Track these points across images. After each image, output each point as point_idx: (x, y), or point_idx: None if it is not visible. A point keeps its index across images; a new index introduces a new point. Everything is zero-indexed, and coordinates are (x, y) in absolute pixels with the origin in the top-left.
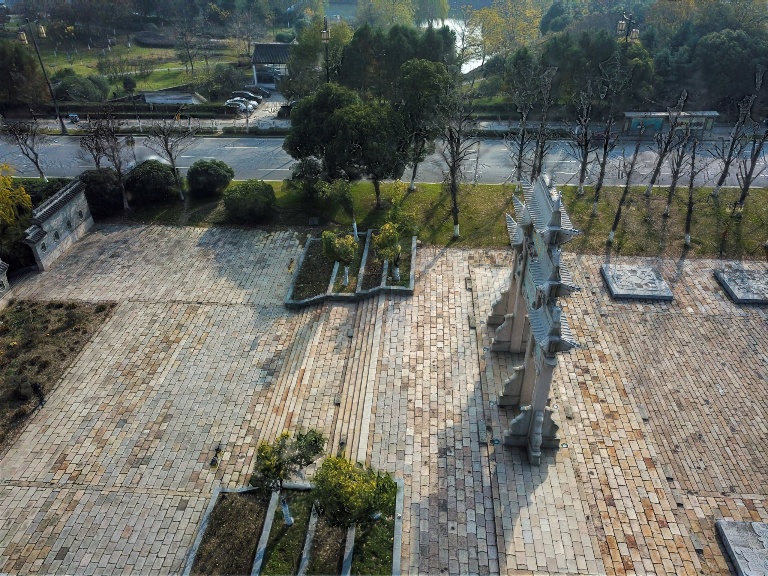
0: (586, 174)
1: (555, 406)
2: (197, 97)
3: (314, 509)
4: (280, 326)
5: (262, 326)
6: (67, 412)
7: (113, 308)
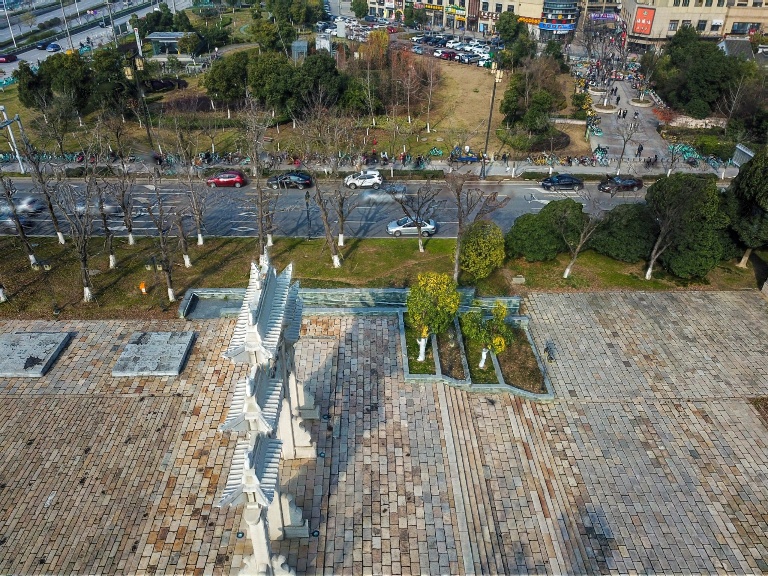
0: None
1: None
2: None
3: (466, 365)
4: None
5: None
6: (763, 462)
7: None
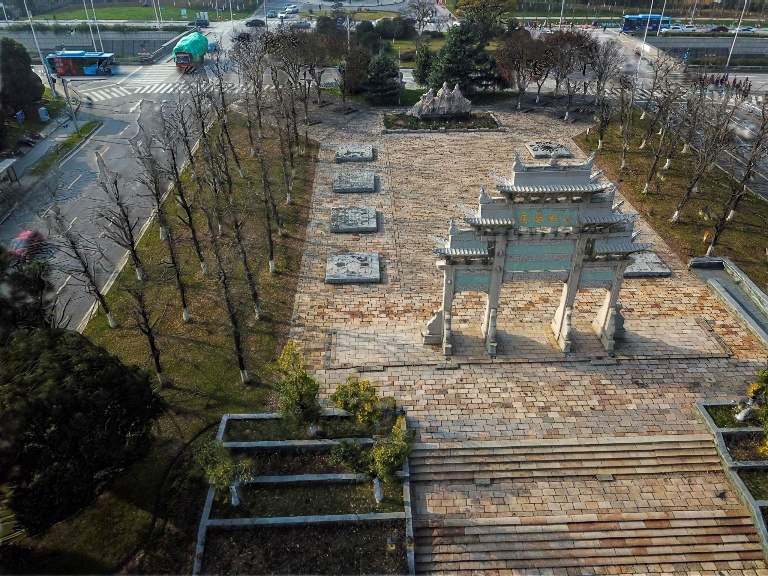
0: (136, 255)
1: None
2: None
3: (763, 464)
4: None
5: None
6: None
7: None
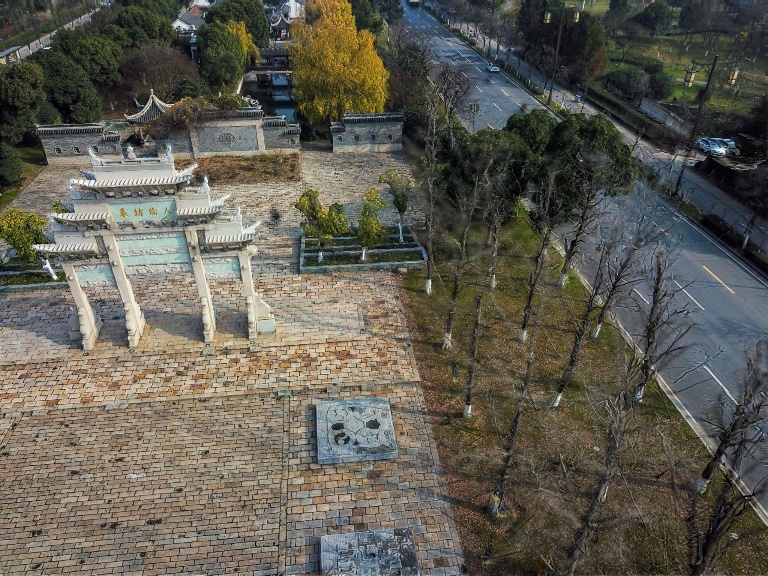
0: None
1: (132, 351)
2: (676, 119)
3: None
4: (278, 237)
5: (277, 231)
6: None
7: (293, 181)
